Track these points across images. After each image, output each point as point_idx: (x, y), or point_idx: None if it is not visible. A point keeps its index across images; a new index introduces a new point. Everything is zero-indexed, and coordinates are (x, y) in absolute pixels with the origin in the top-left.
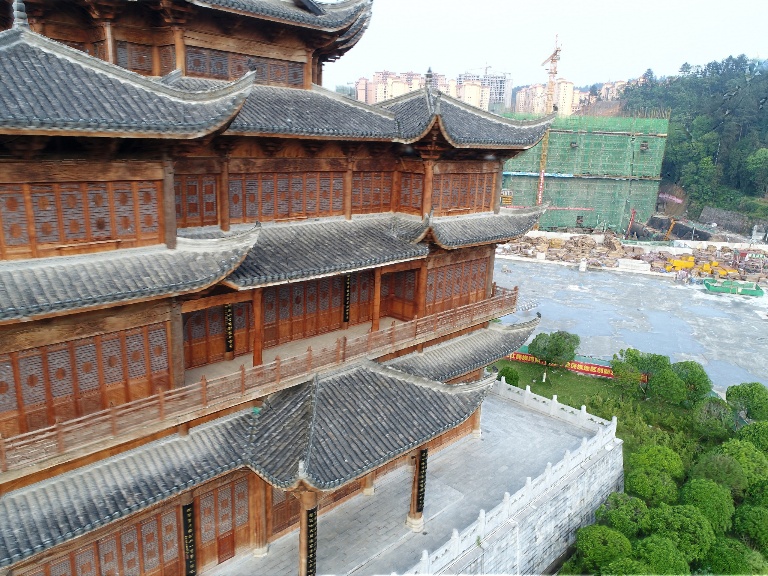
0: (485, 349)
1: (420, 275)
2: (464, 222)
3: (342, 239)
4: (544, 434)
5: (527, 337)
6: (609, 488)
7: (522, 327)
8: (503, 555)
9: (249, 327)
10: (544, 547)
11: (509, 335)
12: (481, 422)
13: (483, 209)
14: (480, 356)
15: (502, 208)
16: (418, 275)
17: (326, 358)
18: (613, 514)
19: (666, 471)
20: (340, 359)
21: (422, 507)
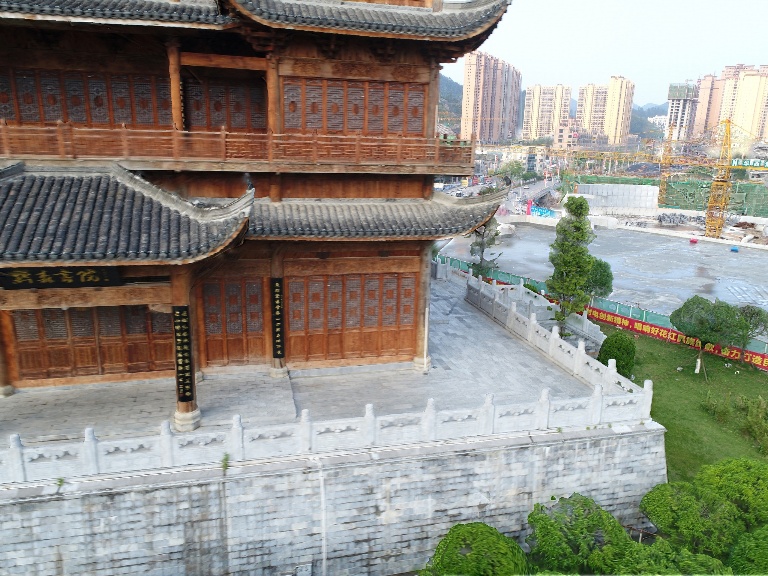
0: (399, 221)
1: (267, 83)
2: (350, 9)
3: (118, 6)
4: (529, 389)
5: (483, 215)
6: (618, 502)
7: (481, 201)
8: (281, 504)
9: (21, 121)
10: (403, 534)
11: (459, 211)
12: (454, 358)
13: (408, 2)
14: (379, 225)
15: (446, 2)
16: (267, 84)
17: (40, 145)
18: (539, 521)
19: (748, 506)
20: (69, 154)
21: (186, 396)
